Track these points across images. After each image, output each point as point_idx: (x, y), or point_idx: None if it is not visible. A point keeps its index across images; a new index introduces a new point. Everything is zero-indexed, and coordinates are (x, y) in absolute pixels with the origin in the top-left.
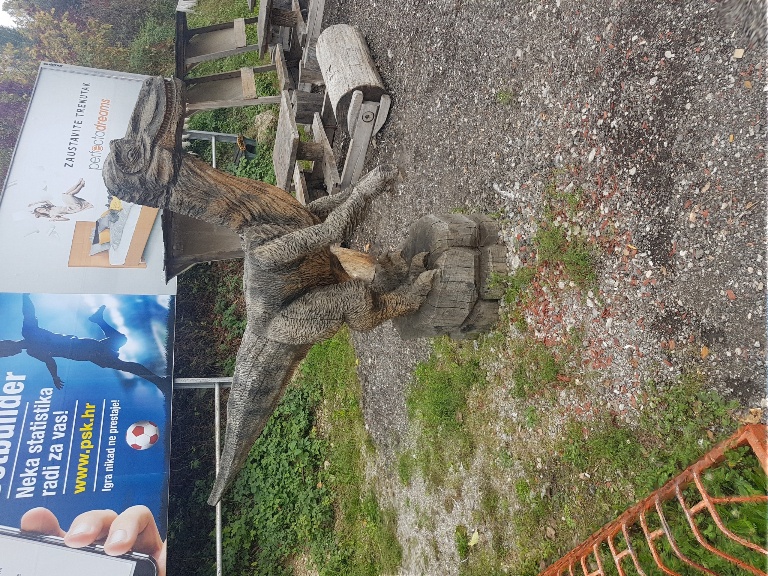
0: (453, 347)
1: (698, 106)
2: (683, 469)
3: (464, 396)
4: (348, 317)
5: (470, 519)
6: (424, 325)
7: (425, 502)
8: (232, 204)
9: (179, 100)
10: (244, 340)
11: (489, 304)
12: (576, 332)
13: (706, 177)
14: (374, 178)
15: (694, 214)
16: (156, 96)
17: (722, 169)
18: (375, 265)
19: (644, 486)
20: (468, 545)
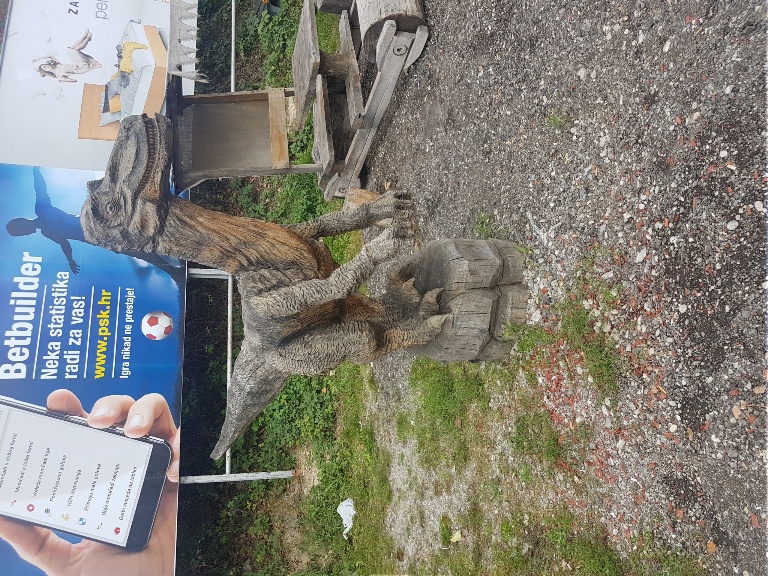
0: None
1: None
2: None
3: (465, 405)
4: None
5: (456, 517)
6: None
7: (417, 470)
8: (226, 251)
9: (163, 146)
10: (242, 352)
11: (502, 345)
12: (585, 428)
13: (763, 379)
14: (386, 243)
15: (738, 410)
16: (136, 141)
17: None
18: None
19: None
20: (451, 538)
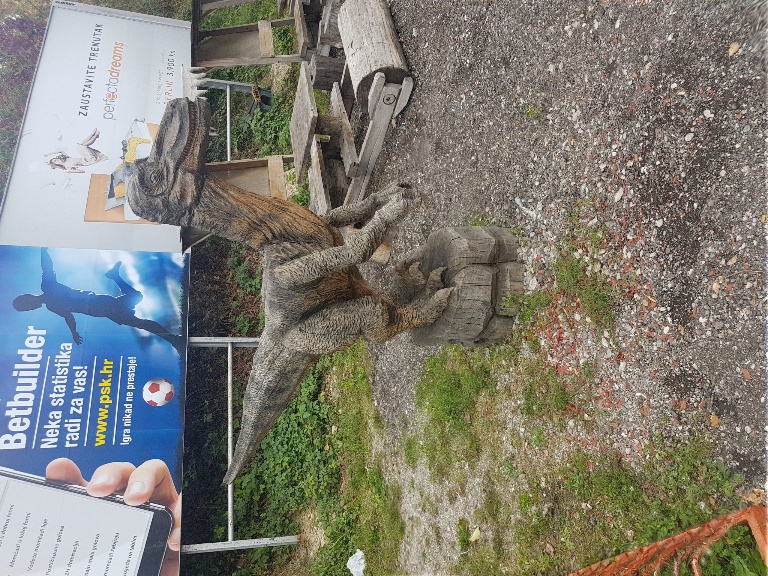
0: (465, 349)
1: (733, 176)
2: (683, 527)
3: (473, 399)
4: (364, 332)
5: (472, 516)
6: (438, 337)
7: (430, 488)
8: (253, 223)
9: (202, 122)
10: (261, 344)
11: (504, 320)
12: (589, 367)
13: (733, 250)
14: (396, 205)
15: (718, 285)
16: (179, 118)
17: (751, 248)
18: (390, 248)
19: (643, 535)
20: (469, 539)
